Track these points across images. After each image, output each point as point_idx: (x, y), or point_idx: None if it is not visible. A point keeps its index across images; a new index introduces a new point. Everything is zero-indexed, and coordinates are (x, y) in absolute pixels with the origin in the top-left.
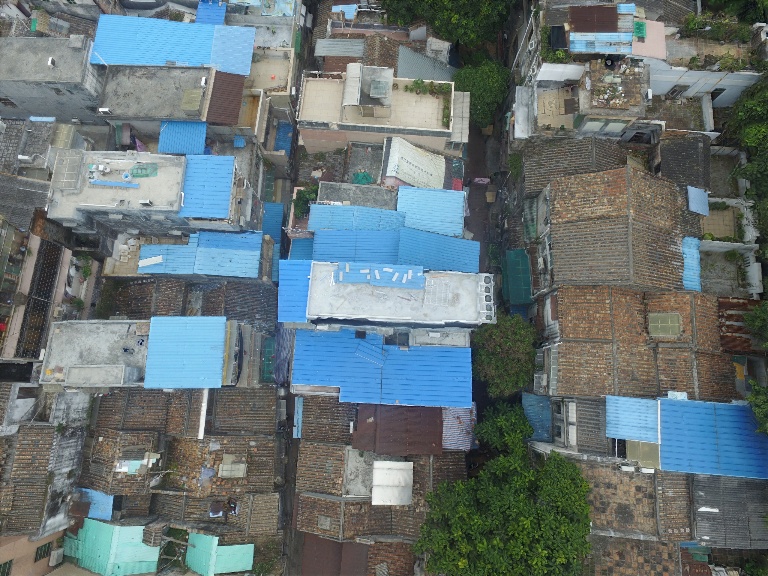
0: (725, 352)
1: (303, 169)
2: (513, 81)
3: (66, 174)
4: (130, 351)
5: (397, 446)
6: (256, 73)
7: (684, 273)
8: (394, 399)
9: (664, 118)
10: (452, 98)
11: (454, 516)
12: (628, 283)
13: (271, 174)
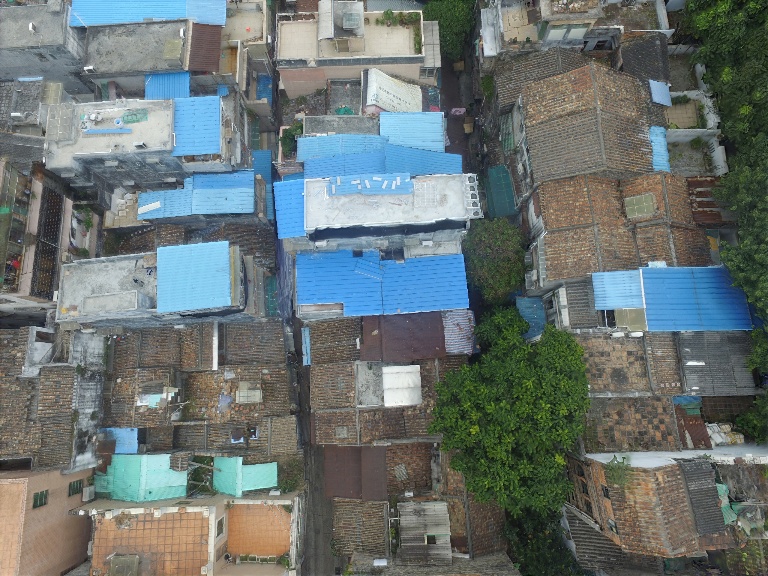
0: (698, 227)
1: (286, 115)
2: (478, 12)
3: (59, 127)
4: (140, 284)
5: (403, 353)
6: (231, 27)
7: (654, 159)
8: (395, 309)
9: (622, 24)
10: (421, 25)
11: (462, 391)
12: (602, 169)
13: (256, 125)
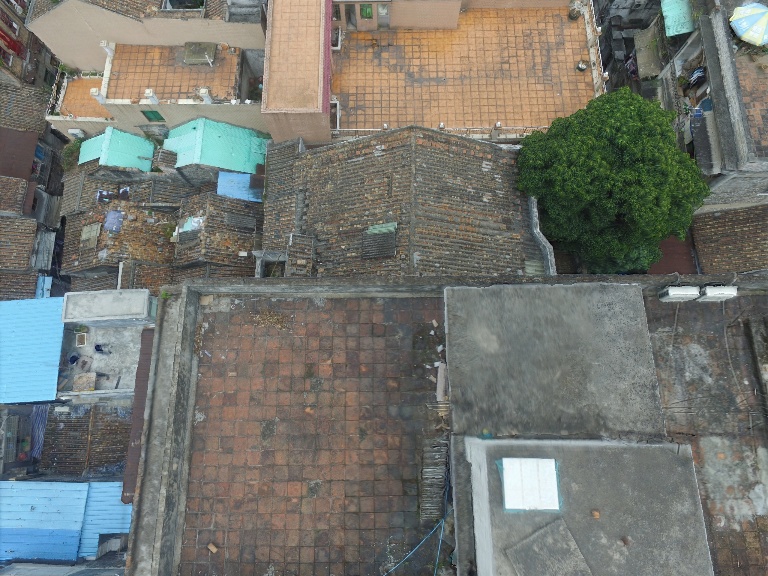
0: None
1: None
2: None
3: None
4: (115, 350)
5: None
6: None
7: None
8: None
9: None
10: None
11: None
12: None
13: None
